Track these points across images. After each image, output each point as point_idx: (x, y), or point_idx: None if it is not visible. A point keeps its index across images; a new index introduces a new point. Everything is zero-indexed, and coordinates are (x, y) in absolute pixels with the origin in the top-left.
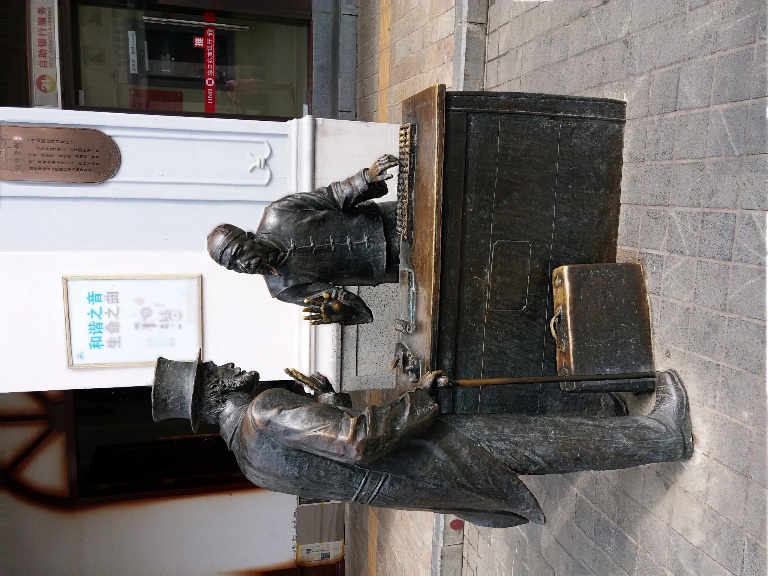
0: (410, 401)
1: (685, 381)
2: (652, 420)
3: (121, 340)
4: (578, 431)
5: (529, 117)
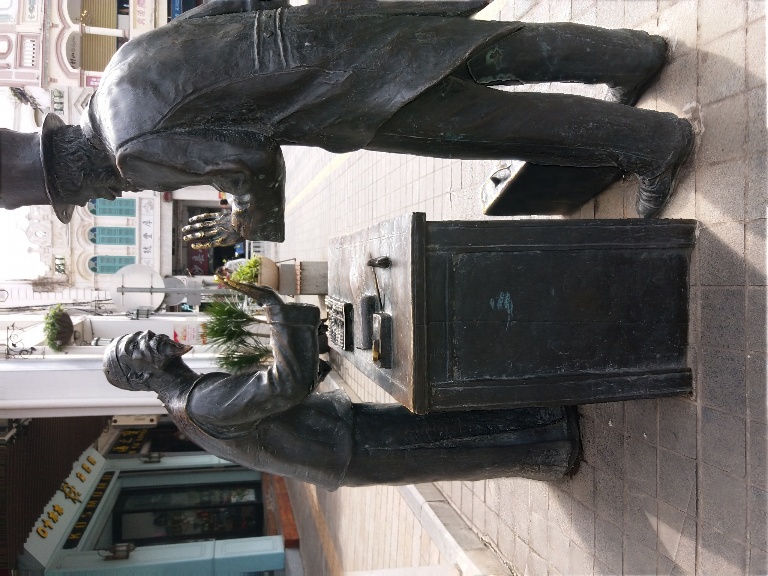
0: None
1: None
2: None
3: None
4: None
5: None
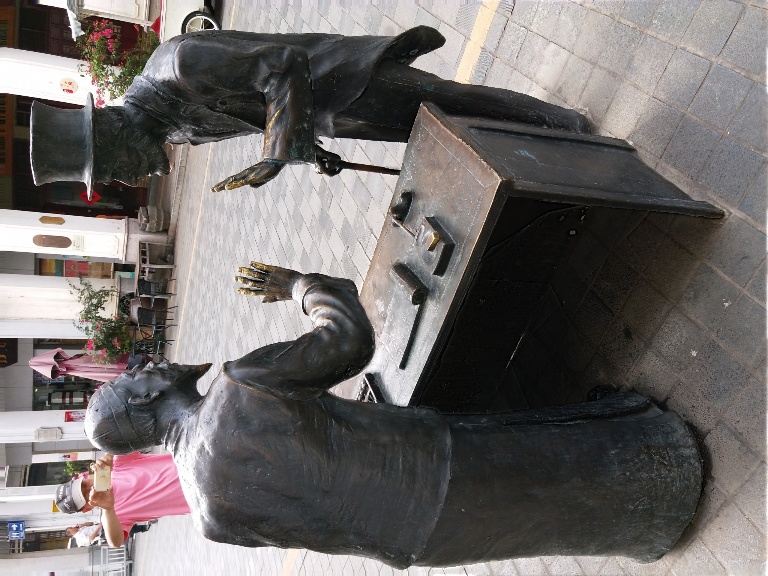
0: None
1: None
2: None
3: None
4: None
5: None
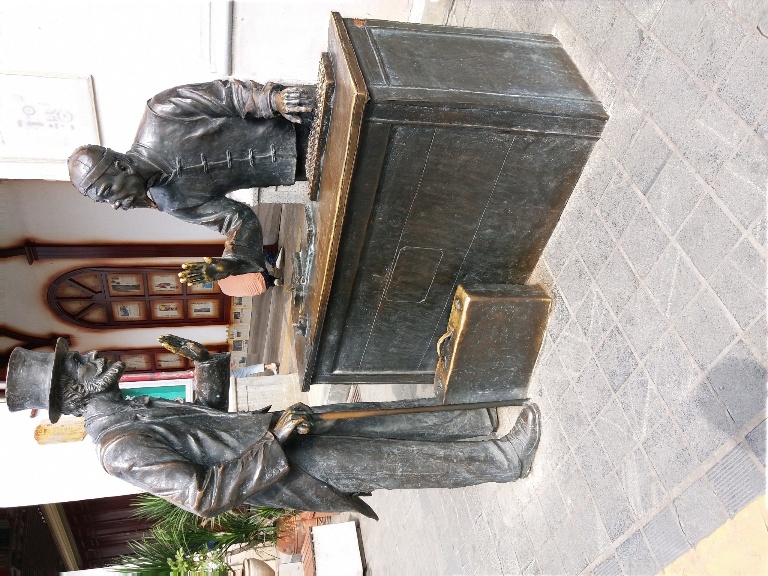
0: (262, 463)
1: (543, 427)
2: (500, 453)
3: (4, 134)
4: (425, 467)
5: (475, 130)
